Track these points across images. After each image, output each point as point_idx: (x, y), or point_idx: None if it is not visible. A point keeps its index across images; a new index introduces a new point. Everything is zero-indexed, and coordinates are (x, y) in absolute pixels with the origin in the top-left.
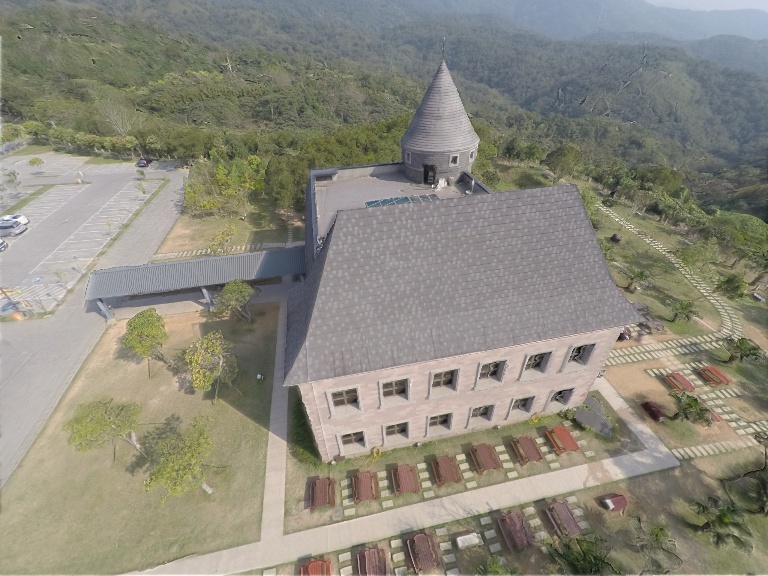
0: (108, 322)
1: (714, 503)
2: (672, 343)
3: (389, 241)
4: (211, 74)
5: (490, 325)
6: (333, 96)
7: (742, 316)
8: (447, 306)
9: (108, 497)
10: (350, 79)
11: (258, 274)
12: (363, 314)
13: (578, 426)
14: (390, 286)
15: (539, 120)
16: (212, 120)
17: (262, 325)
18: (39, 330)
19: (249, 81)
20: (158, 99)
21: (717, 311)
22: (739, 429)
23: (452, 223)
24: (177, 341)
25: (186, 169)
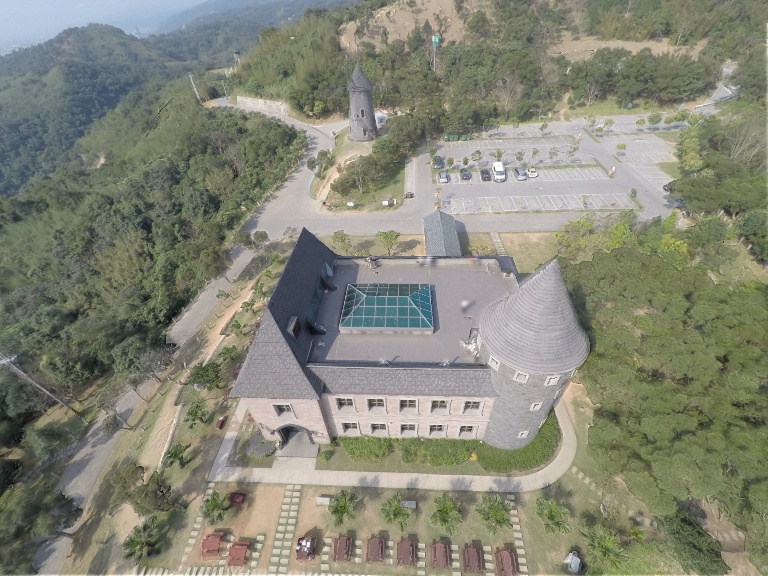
0: None
1: (182, 462)
2: None
3: None
4: None
5: None
6: None
7: None
8: None
9: None
10: None
11: None
12: None
13: None
14: None
15: None
16: None
17: None
18: None
19: None
20: None
21: None
22: (190, 574)
23: None
24: None
25: (681, 214)
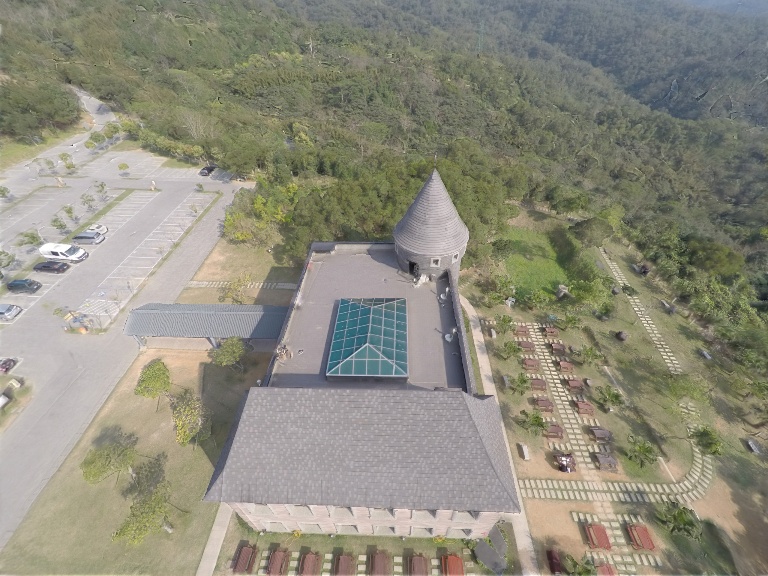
0: (140, 349)
1: None
2: (617, 486)
3: (291, 413)
4: (292, 56)
5: (372, 487)
6: (405, 84)
7: (718, 467)
8: (338, 465)
9: (106, 514)
10: (429, 61)
11: (253, 334)
12: (268, 460)
13: (475, 558)
14: (291, 444)
15: (637, 119)
16: (285, 106)
17: (252, 376)
18: (93, 346)
19: (326, 64)
20: (240, 83)
21: (692, 455)
22: None
23: (344, 407)
24: (185, 379)
25: (239, 182)
